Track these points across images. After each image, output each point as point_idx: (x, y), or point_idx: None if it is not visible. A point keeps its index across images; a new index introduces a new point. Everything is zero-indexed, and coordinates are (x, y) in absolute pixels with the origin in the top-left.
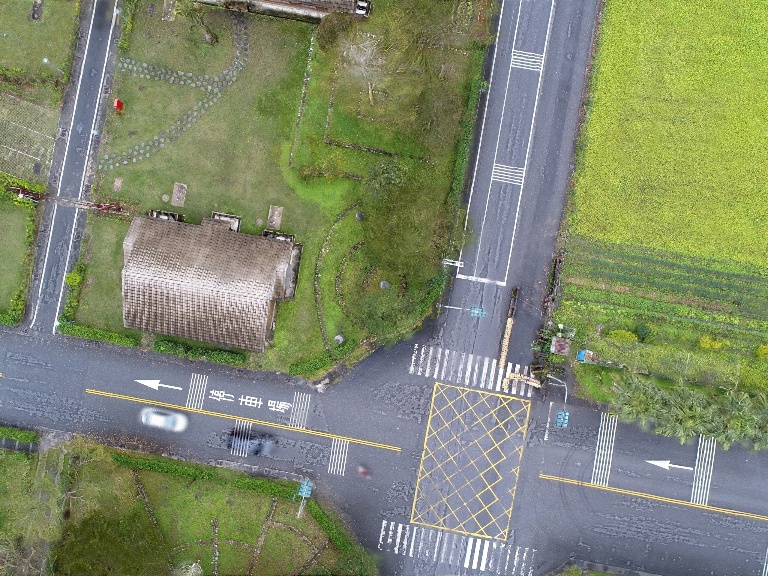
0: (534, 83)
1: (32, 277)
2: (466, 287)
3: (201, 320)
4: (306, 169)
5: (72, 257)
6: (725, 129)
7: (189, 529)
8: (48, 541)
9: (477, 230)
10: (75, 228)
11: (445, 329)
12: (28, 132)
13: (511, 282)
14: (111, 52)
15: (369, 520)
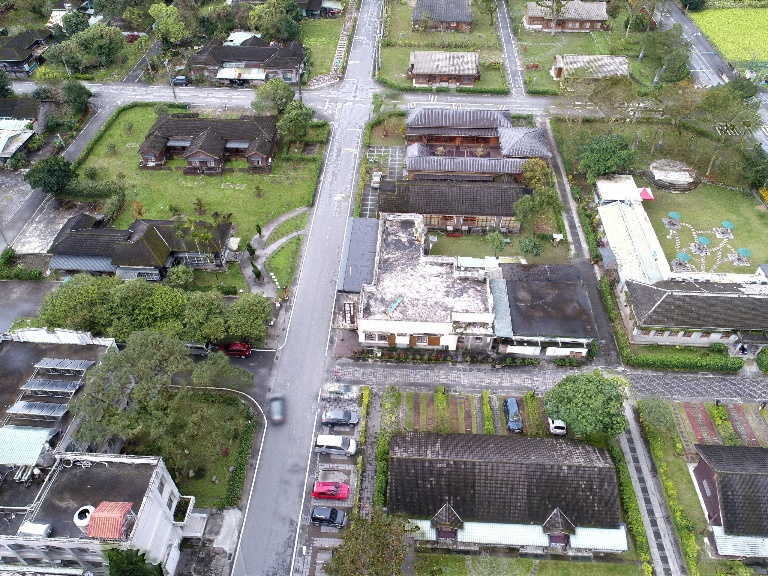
0: (682, 35)
1: (507, 84)
2: (697, 72)
3: (599, 69)
4: (616, 41)
5: (522, 79)
6: (764, 37)
7: (624, 134)
8: (584, 91)
9: (689, 61)
10: (520, 73)
11: (697, 81)
12: (489, 56)
13: (714, 70)
14: (514, 41)
15: (708, 128)
